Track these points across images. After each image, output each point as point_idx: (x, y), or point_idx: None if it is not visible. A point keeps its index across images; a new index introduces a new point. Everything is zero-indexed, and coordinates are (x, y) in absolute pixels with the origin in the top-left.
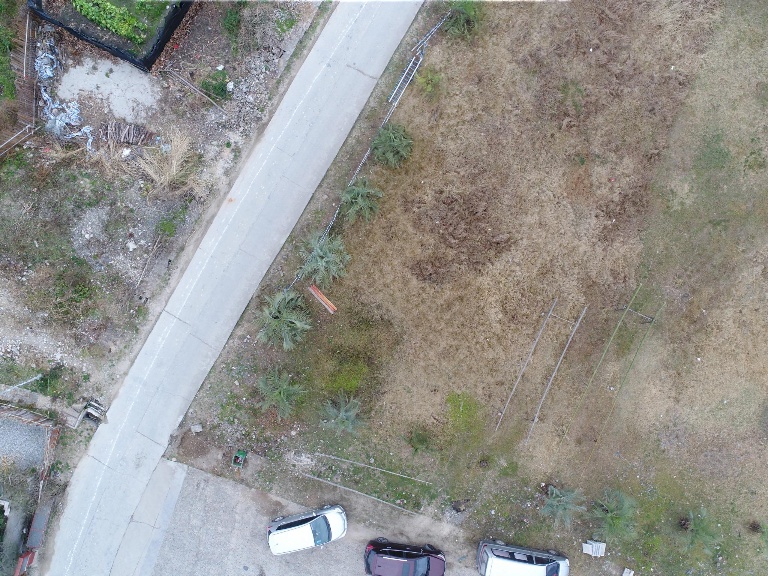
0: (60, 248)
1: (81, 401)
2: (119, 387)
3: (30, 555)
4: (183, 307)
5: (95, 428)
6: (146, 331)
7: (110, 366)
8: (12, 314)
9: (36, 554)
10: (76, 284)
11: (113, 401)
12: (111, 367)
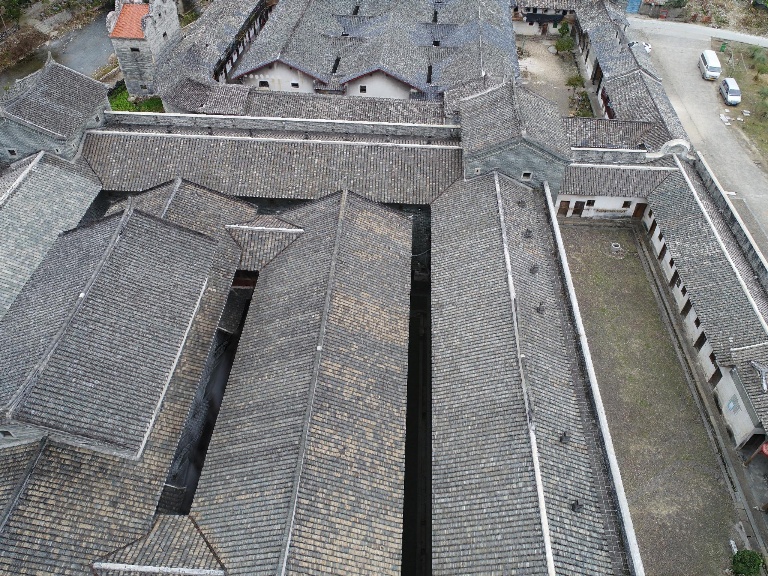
0: (767, 23)
1: (719, 26)
2: (729, 31)
3: (665, 16)
4: (767, 40)
5: (712, 28)
6: (752, 35)
7: (735, 30)
8: (738, 17)
9: (663, 19)
10: (759, 25)
11: (724, 30)
12: (735, 30)
